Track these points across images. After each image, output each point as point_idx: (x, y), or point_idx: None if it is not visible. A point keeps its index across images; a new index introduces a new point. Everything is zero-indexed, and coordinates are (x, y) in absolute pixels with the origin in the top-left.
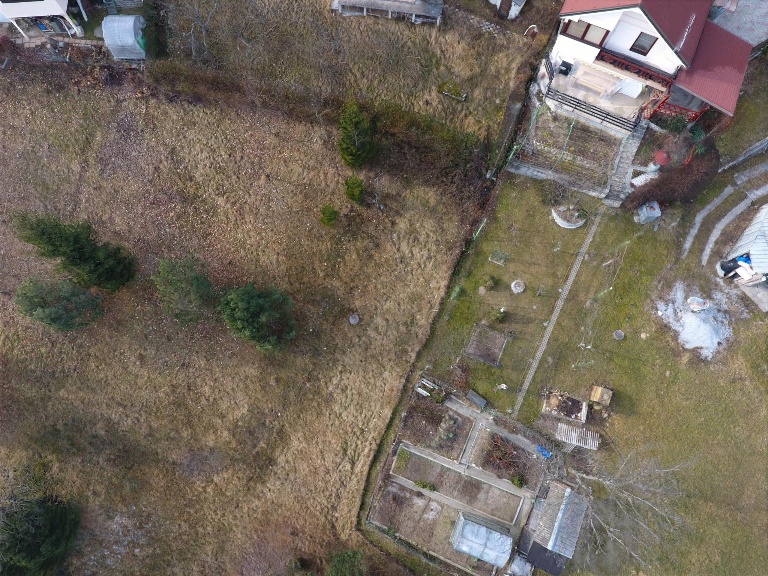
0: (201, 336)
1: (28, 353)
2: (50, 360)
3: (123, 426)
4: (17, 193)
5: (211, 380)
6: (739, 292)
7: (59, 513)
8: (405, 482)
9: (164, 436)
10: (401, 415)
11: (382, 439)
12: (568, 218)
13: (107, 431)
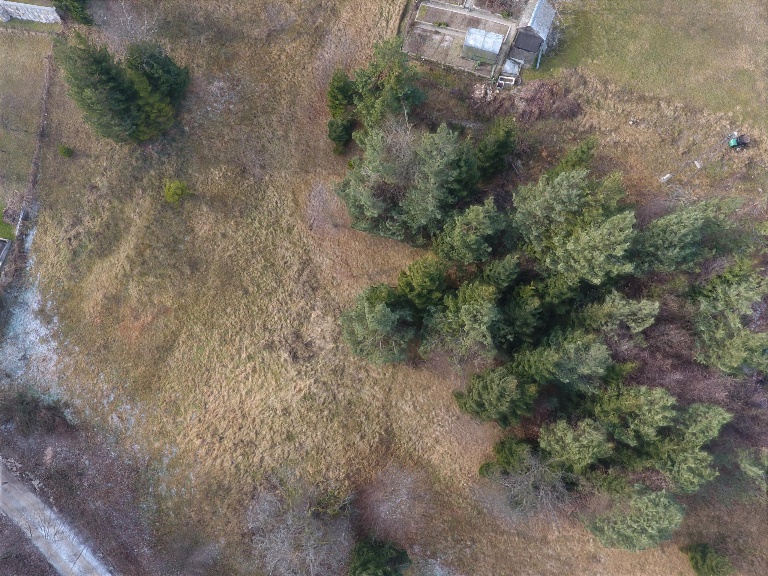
0: None
1: None
2: None
3: (217, 14)
4: None
5: None
6: None
7: (176, 66)
8: (426, 26)
9: (248, 19)
10: None
11: (408, 2)
12: None
13: (205, 19)
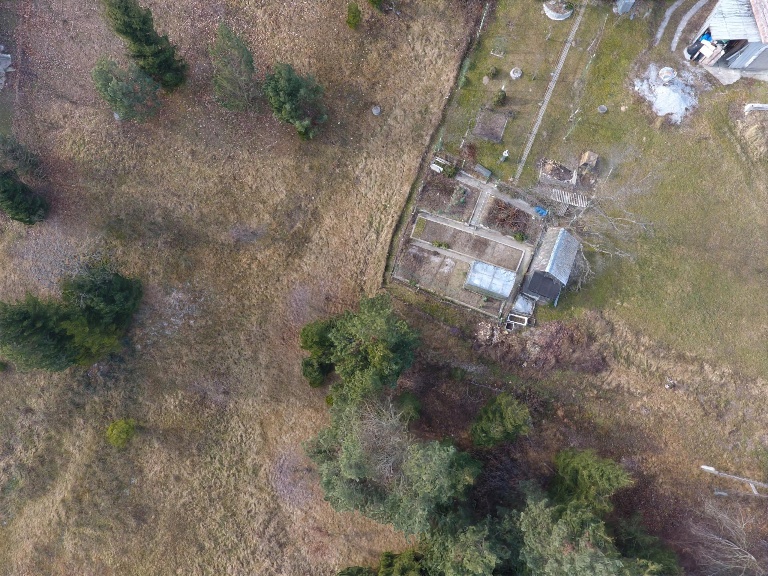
0: (244, 132)
1: (93, 155)
2: (113, 160)
3: (178, 213)
4: (83, 12)
5: (253, 170)
6: (703, 71)
7: (126, 282)
8: (423, 245)
9: (213, 221)
10: (418, 190)
11: (402, 212)
12: (557, 10)
13: (164, 218)
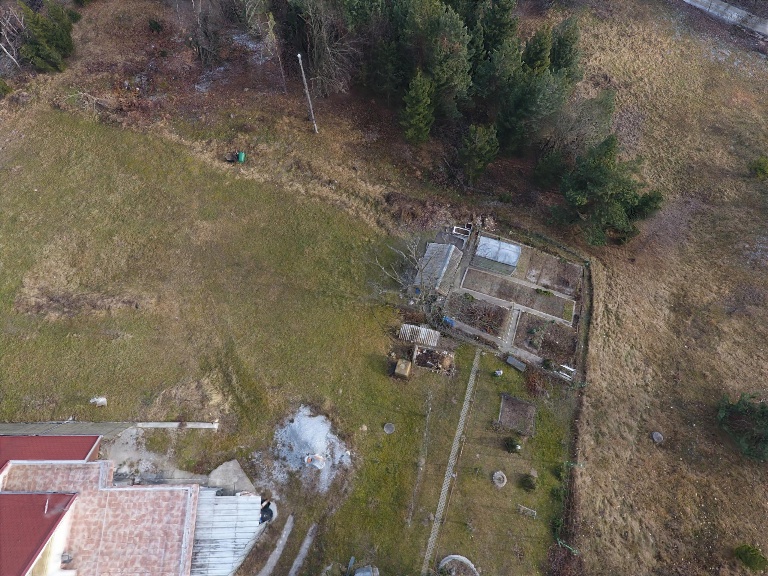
0: None
1: None
2: None
3: None
4: None
5: (766, 374)
6: (257, 483)
7: None
8: (560, 296)
9: None
10: None
11: (589, 328)
12: (462, 568)
13: None
